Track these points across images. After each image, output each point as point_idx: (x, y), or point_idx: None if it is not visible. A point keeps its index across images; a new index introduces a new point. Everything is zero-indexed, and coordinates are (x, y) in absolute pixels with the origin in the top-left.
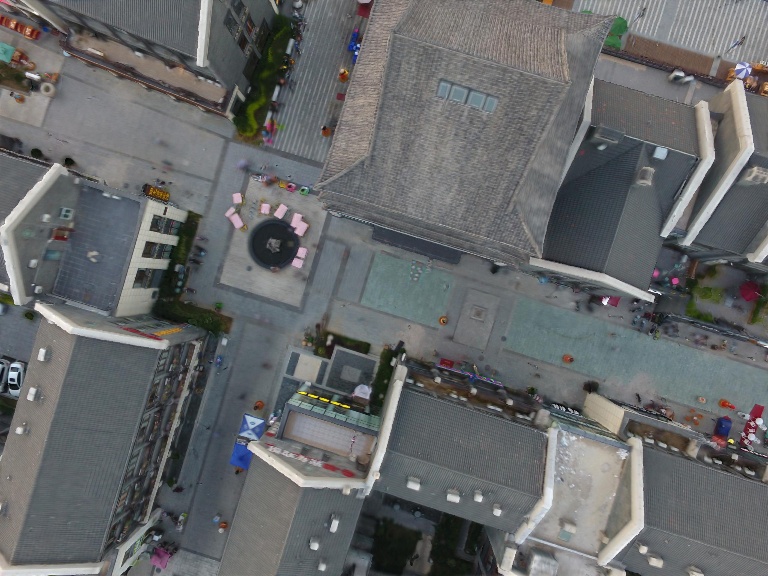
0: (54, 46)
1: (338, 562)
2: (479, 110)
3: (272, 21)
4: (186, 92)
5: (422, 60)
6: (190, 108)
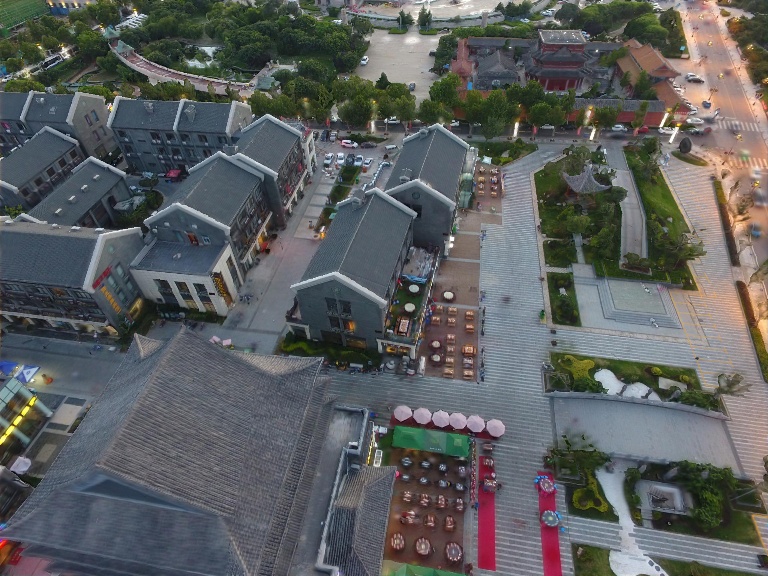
0: None
1: None
2: None
3: (372, 348)
4: None
5: None
6: None
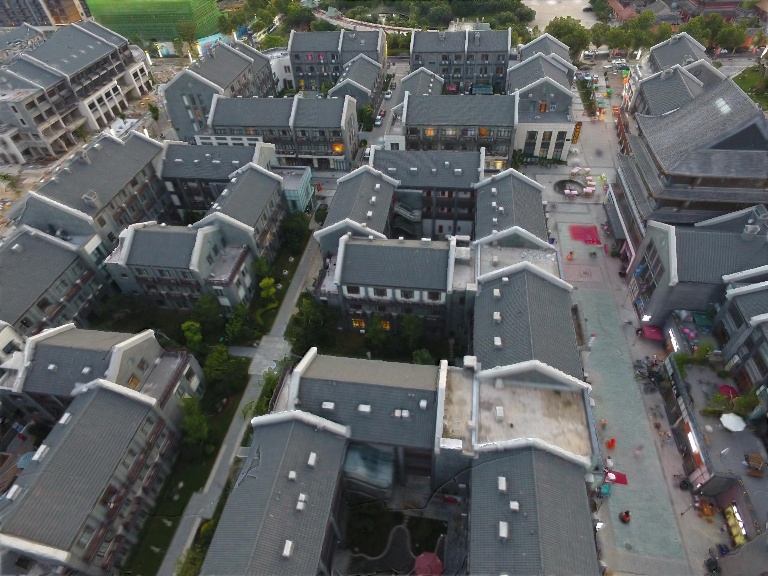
0: (616, 119)
1: (432, 182)
2: None
3: None
4: None
5: None
6: None
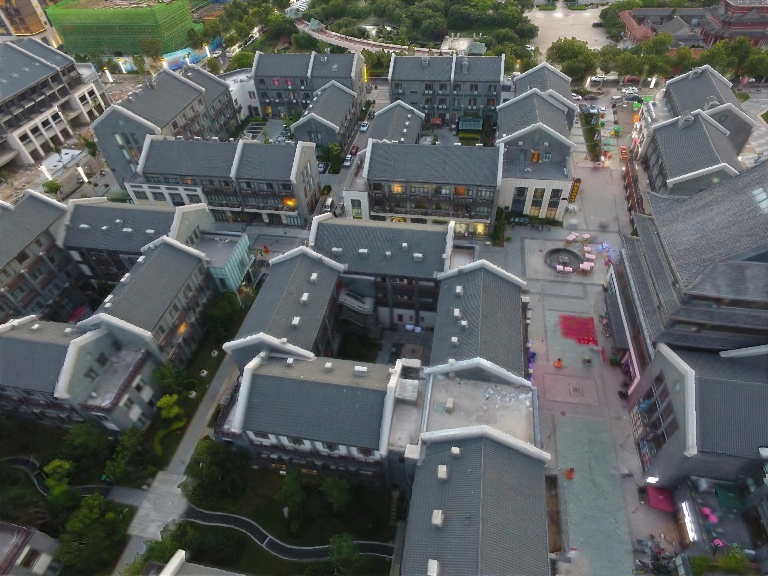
0: (623, 166)
1: (386, 269)
2: None
3: None
4: (641, 198)
5: (766, 175)
6: (627, 215)
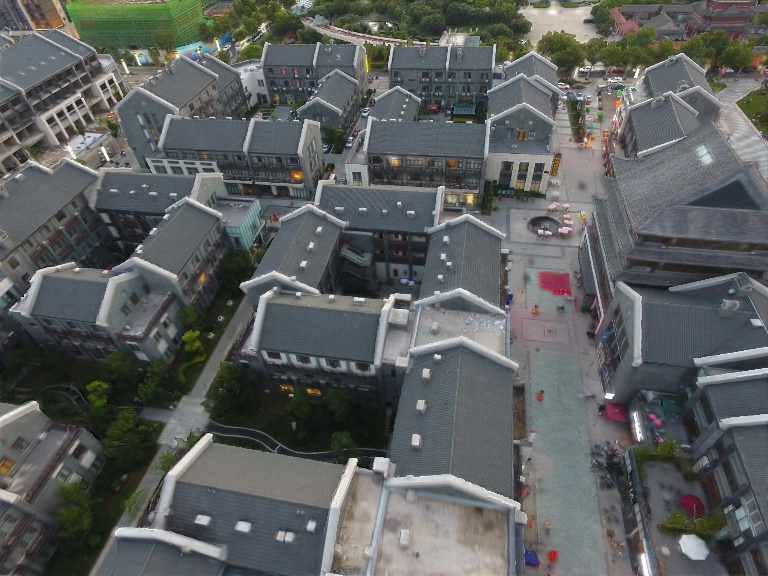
0: None
1: (383, 225)
2: (701, 162)
3: None
4: None
5: None
6: None
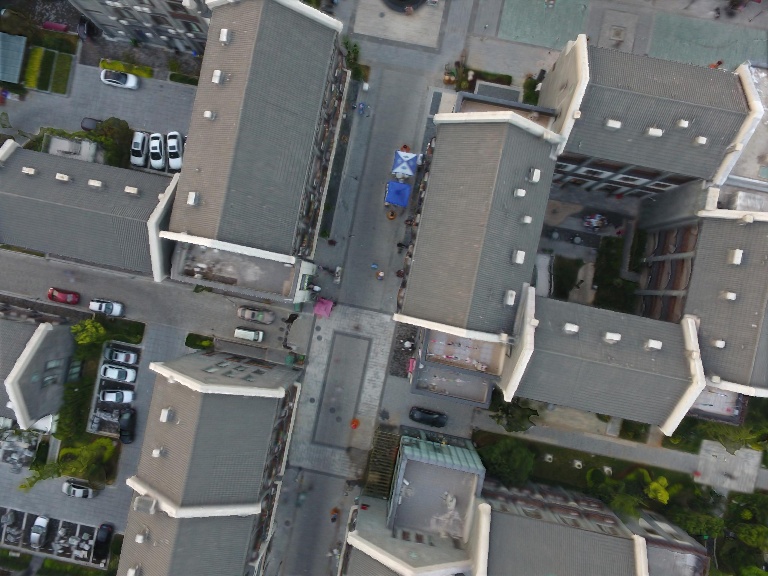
0: None
1: (537, 226)
2: None
3: None
4: None
5: None
6: None
